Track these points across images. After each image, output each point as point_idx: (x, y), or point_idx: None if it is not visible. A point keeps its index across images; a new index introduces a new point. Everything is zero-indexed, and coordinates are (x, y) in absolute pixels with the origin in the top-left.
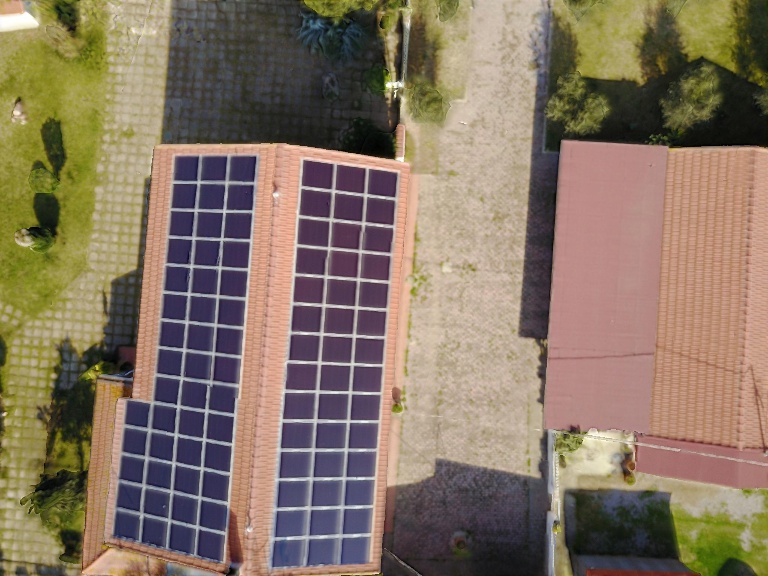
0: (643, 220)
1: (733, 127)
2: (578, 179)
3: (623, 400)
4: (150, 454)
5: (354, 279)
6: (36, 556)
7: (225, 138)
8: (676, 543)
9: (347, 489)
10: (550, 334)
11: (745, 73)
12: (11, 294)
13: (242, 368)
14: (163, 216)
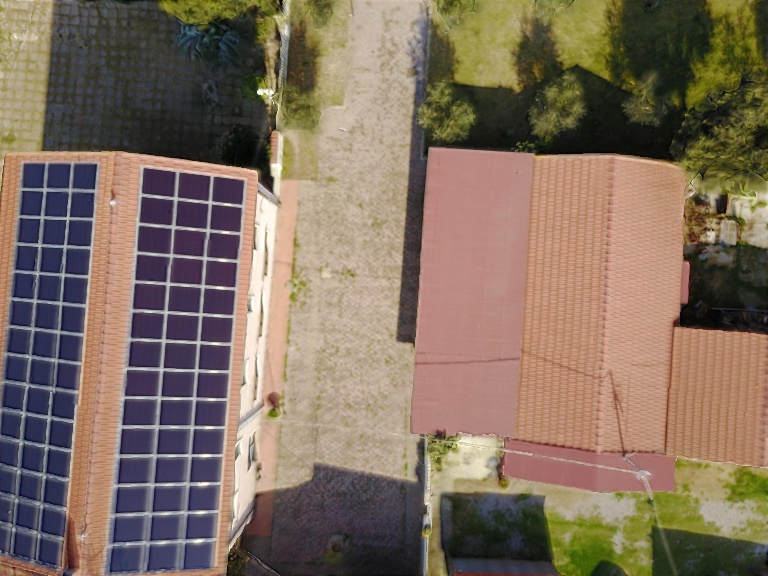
0: (509, 226)
1: (607, 134)
2: (445, 186)
3: (489, 404)
4: None
5: (198, 286)
6: None
7: (106, 144)
8: (550, 545)
9: (190, 494)
10: (417, 339)
11: (619, 81)
12: None
13: (82, 374)
14: (12, 223)
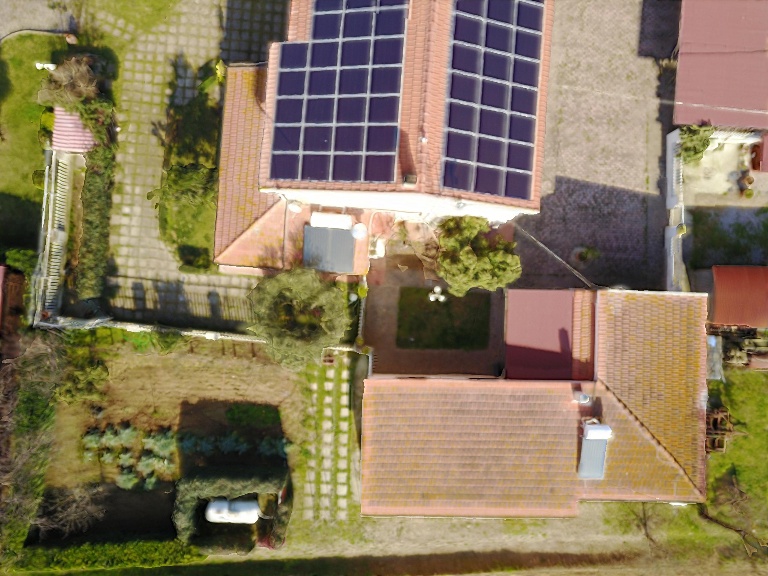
0: None
1: None
2: None
3: (753, 95)
4: (309, 93)
5: None
6: (152, 272)
7: None
8: None
9: (511, 122)
10: (682, 30)
11: None
12: (123, 8)
13: None
14: None
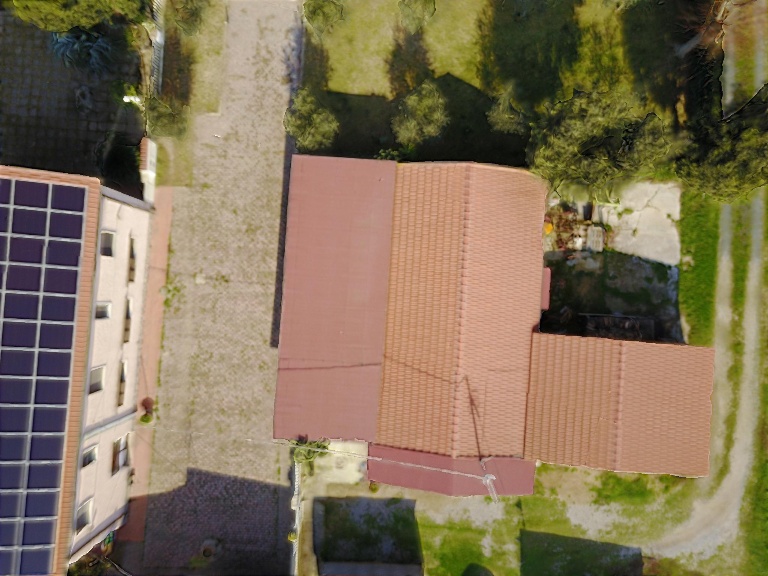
0: (372, 233)
1: (478, 142)
2: (309, 193)
3: (351, 410)
4: None
5: (36, 293)
6: None
7: None
8: (420, 549)
9: (27, 501)
10: (280, 345)
11: (489, 89)
12: None
13: None
14: None
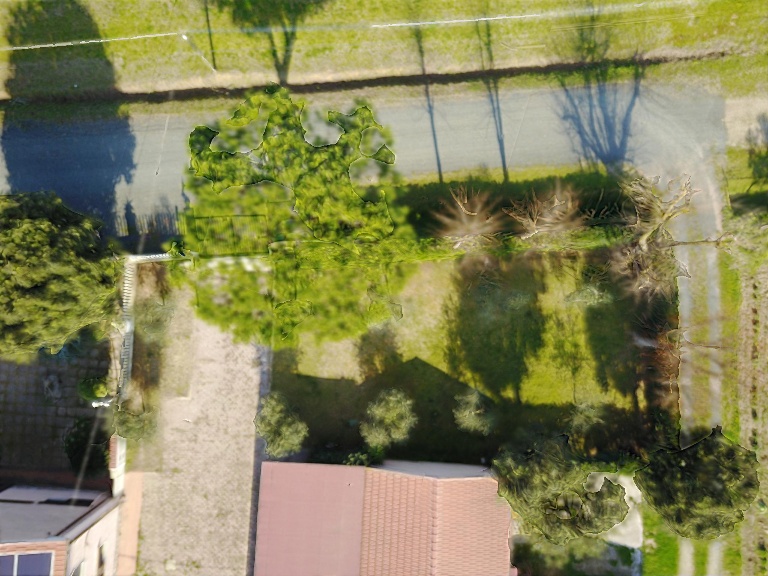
0: (341, 539)
1: (445, 425)
2: (279, 499)
3: None
4: None
5: None
6: None
7: None
8: None
9: None
10: None
11: (456, 373)
12: None
13: None
14: None
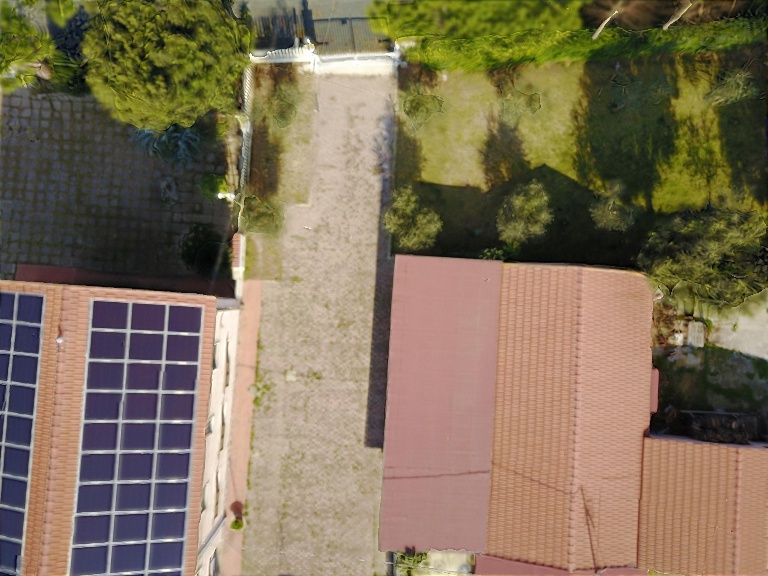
0: (478, 335)
1: (575, 234)
2: (413, 294)
3: (459, 519)
4: None
5: (153, 421)
6: None
7: (59, 242)
8: None
9: None
10: (385, 453)
11: (586, 181)
12: None
13: (25, 523)
14: None
